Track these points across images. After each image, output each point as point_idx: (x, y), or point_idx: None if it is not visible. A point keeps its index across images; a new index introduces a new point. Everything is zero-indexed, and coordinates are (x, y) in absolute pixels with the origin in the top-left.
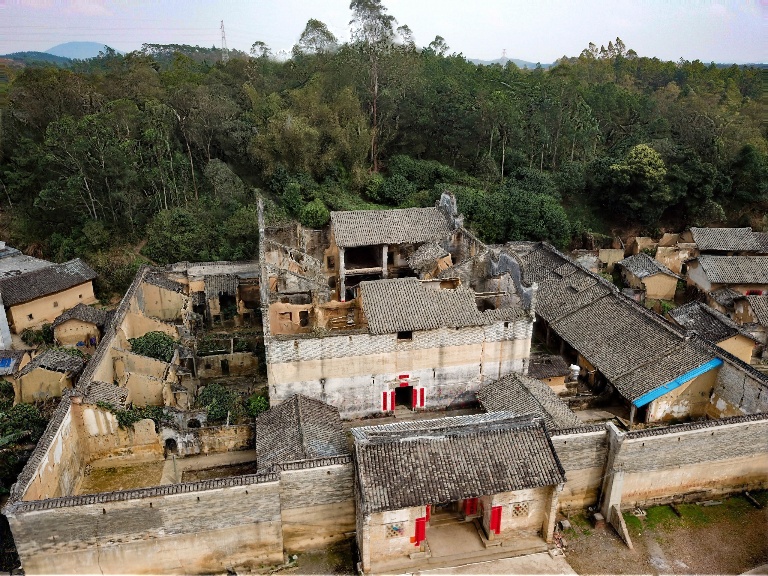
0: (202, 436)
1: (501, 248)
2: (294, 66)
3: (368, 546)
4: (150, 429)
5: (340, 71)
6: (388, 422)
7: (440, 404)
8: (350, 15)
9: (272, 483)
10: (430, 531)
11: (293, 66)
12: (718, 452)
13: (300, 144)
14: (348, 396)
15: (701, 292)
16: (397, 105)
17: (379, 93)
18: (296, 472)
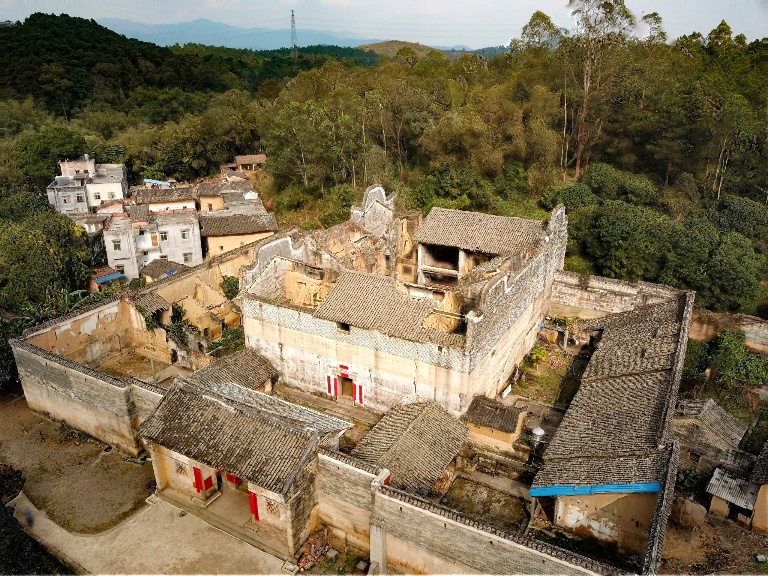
0: (191, 356)
1: (625, 286)
2: (510, 61)
3: (156, 468)
4: (163, 337)
5: (548, 66)
6: (327, 405)
7: (378, 408)
8: (574, 5)
9: (120, 388)
10: (233, 492)
11: (509, 61)
12: (507, 572)
13: (463, 139)
14: (300, 367)
15: None
16: (610, 106)
17: (591, 92)
18: (142, 389)
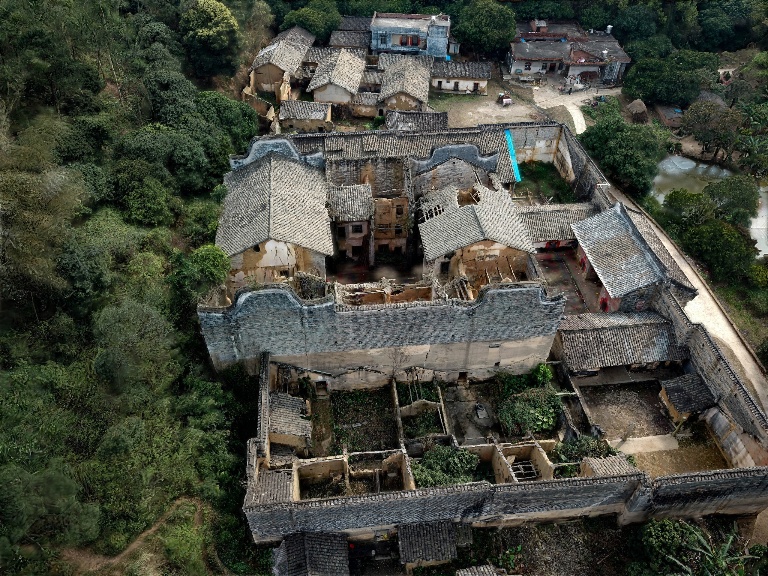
0: None
1: None
2: None
3: None
4: None
5: None
6: None
7: None
8: None
9: None
10: None
11: None
12: None
13: (72, 202)
14: None
15: (340, 106)
16: None
17: None
18: None
